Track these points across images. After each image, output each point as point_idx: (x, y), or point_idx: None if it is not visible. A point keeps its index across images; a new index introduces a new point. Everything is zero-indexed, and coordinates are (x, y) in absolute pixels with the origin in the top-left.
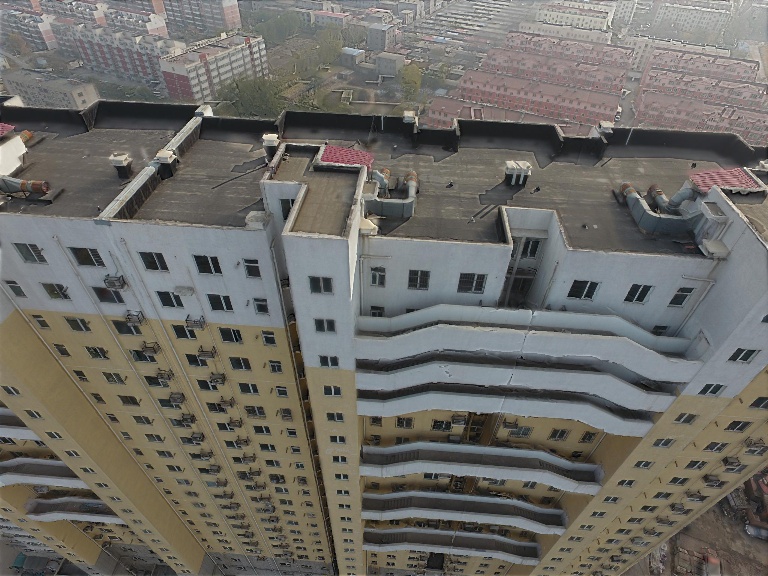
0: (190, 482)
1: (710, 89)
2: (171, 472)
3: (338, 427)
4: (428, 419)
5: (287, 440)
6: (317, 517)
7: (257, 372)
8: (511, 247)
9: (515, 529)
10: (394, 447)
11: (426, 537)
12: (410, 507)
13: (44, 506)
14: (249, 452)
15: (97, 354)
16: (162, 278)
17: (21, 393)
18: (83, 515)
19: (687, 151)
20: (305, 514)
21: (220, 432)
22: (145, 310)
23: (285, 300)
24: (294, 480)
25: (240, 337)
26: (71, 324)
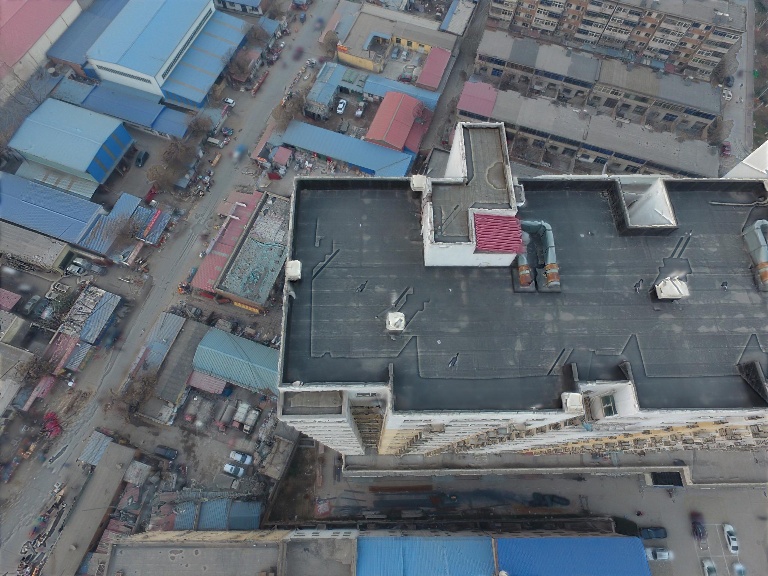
0: None
1: None
2: None
3: None
4: None
5: None
6: None
7: None
8: (661, 178)
9: None
10: None
11: None
12: None
13: None
14: None
15: None
16: None
17: None
18: None
19: (447, 404)
20: None
21: None
22: None
23: None
24: None
25: None
26: None
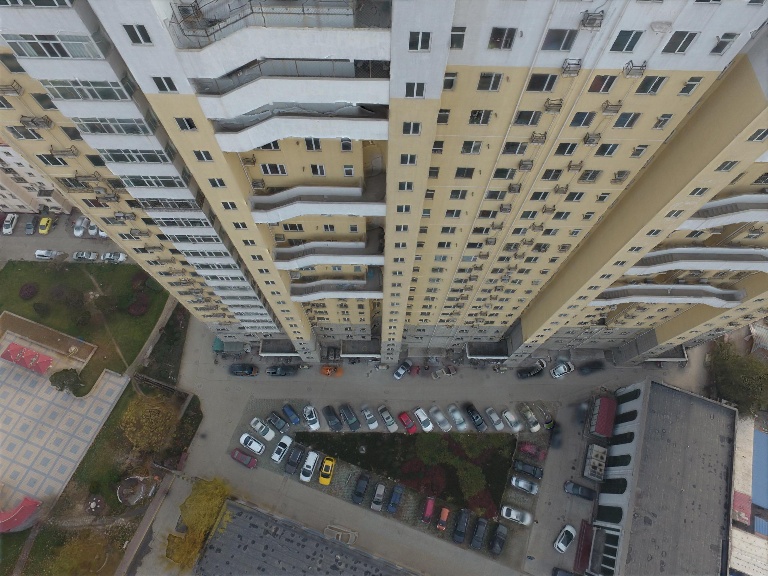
0: (450, 258)
1: None
2: (439, 249)
3: (717, 177)
4: (760, 172)
5: (593, 206)
6: (541, 284)
7: (637, 129)
8: None
9: (720, 281)
10: (713, 202)
11: (646, 291)
12: (680, 260)
13: (298, 290)
14: (538, 222)
15: (477, 119)
16: (646, 11)
17: (420, 161)
18: (347, 292)
19: None
20: (533, 281)
21: (529, 202)
22: (586, 57)
23: (751, 35)
24: (559, 247)
25: (655, 87)
26: (480, 82)
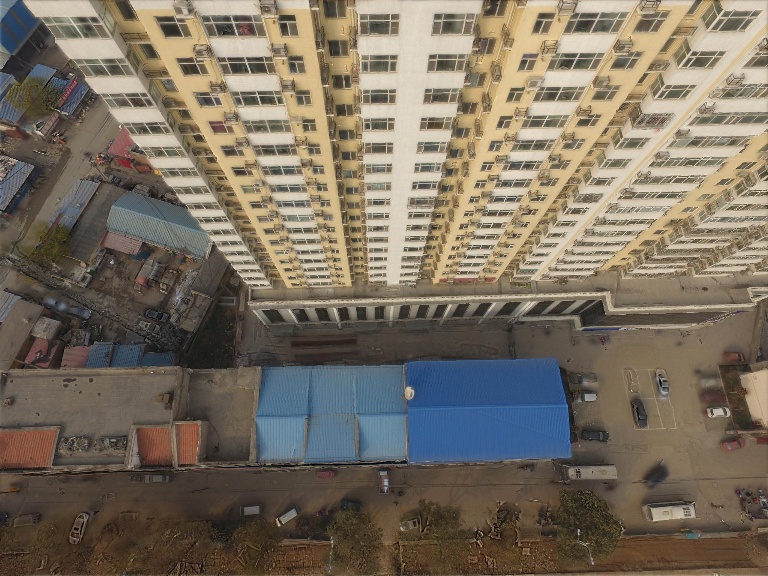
0: None
1: None
2: None
3: None
4: None
5: None
6: None
7: None
8: None
9: None
10: None
11: None
12: None
13: None
14: None
15: None
16: None
17: None
18: None
19: None
20: None
21: None
22: None
23: None
24: None
25: None
26: None
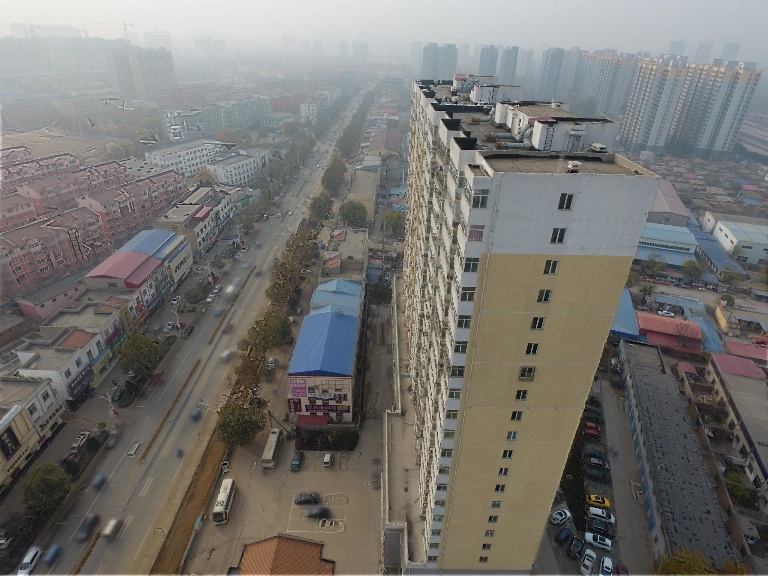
0: None
1: (40, 170)
2: None
3: None
4: None
5: None
6: None
7: None
8: None
9: None
10: None
11: None
12: None
13: None
14: None
15: None
16: None
17: None
18: None
19: None
20: None
21: None
22: None
23: None
24: None
25: None
26: None
